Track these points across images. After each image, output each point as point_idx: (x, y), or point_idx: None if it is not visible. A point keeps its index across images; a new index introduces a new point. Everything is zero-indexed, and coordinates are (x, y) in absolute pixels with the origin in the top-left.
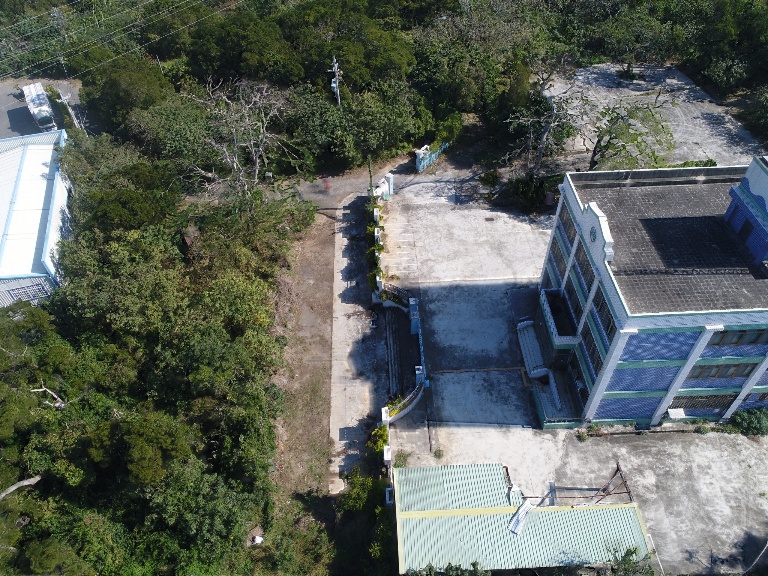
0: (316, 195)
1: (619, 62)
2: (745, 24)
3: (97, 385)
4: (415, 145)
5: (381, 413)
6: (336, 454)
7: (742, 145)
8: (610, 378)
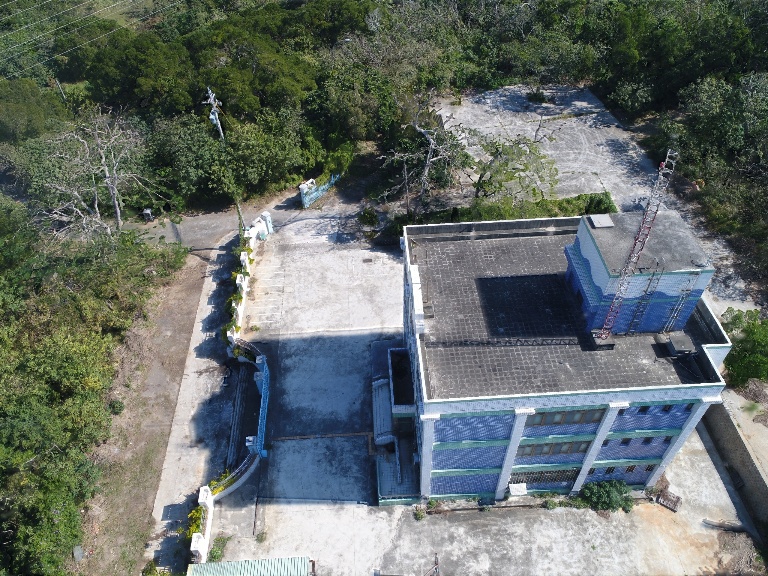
0: (194, 234)
1: None
2: (651, 46)
3: None
4: (306, 177)
5: None
6: (154, 537)
7: (642, 175)
8: (433, 458)
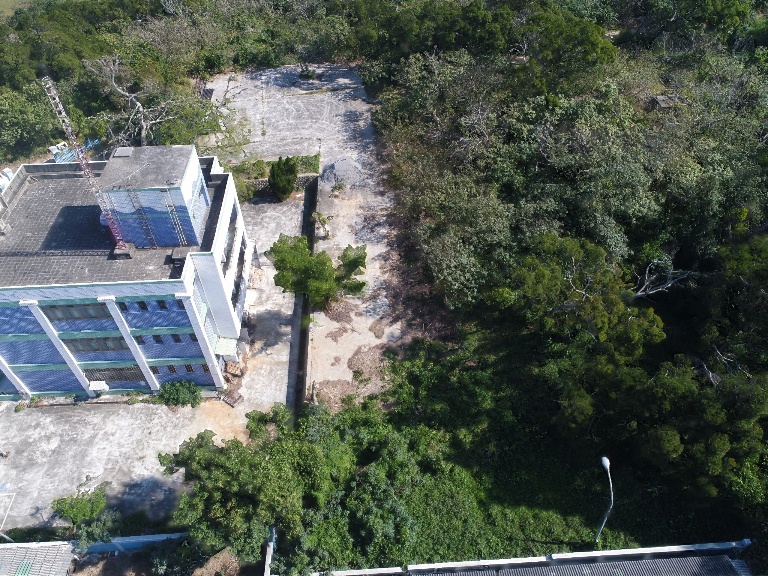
0: None
1: (310, 63)
2: (389, 26)
3: None
4: None
5: None
6: None
7: (357, 141)
8: None
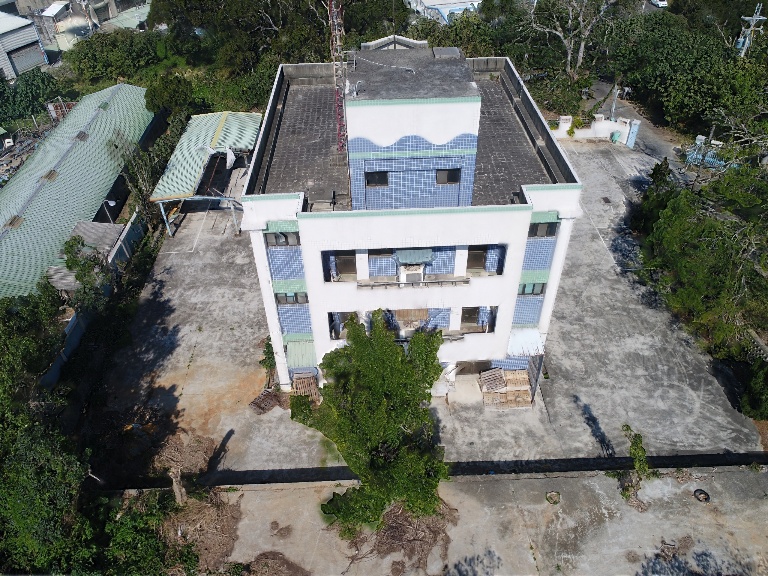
0: None
1: None
2: None
3: None
4: None
5: None
6: None
7: None
8: None
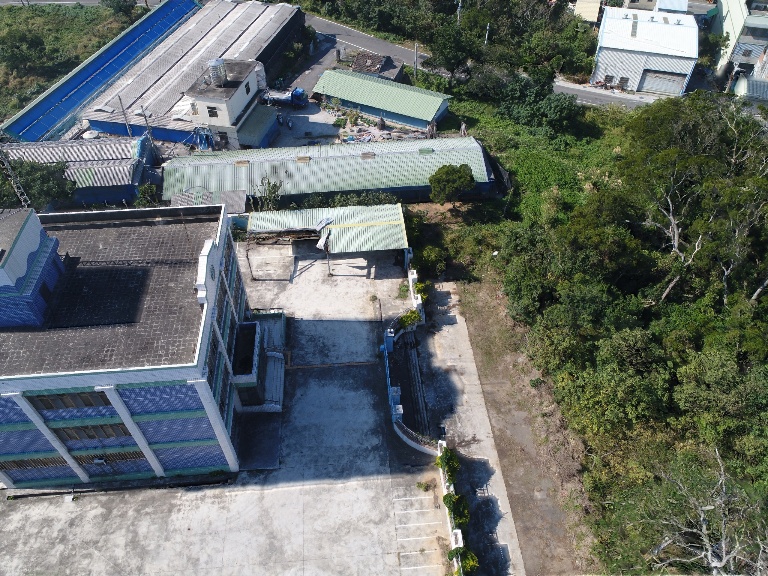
0: None
1: None
2: None
3: (697, 340)
4: None
5: (423, 336)
6: (456, 306)
7: None
8: None
